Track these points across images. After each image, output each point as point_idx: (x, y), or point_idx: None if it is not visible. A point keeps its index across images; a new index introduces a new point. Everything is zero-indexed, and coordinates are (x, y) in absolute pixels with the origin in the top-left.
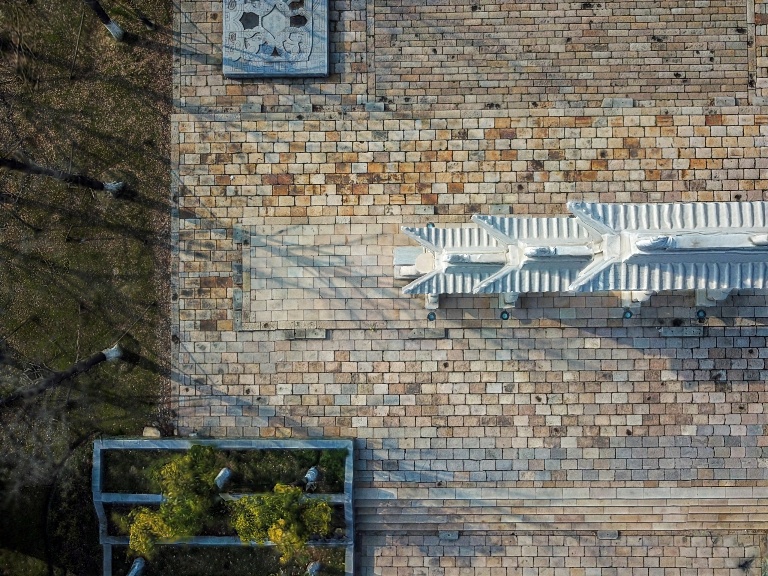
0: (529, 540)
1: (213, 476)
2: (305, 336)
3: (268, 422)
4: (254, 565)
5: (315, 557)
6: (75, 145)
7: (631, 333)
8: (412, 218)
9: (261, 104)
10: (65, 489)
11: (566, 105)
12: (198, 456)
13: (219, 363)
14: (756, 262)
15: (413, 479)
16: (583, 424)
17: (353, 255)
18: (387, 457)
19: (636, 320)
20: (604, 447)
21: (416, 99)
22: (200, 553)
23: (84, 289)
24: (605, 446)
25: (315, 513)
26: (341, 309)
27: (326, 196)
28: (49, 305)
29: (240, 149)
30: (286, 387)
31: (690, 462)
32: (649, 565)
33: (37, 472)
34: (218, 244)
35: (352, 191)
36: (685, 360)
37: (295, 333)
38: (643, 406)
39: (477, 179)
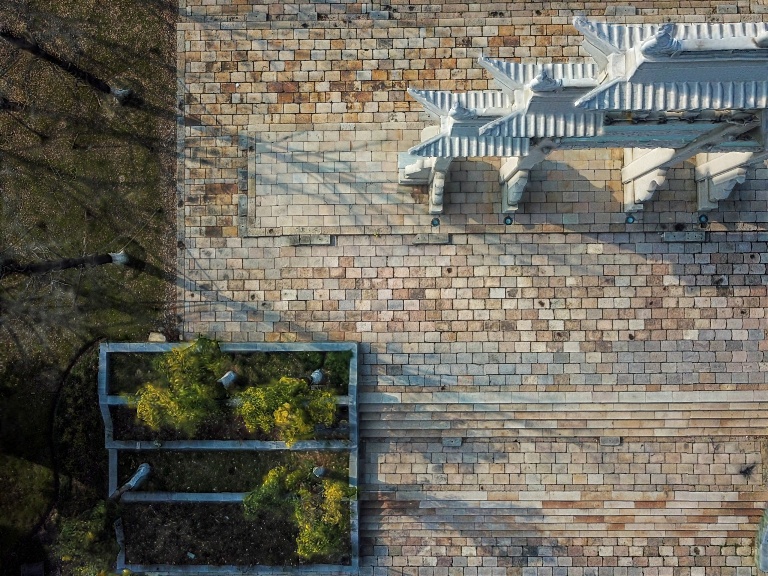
0: (532, 447)
1: (219, 367)
2: (310, 242)
3: (273, 327)
4: (259, 470)
5: (319, 462)
6: (82, 53)
7: (633, 238)
8: (416, 124)
9: (266, 13)
10: (71, 395)
11: (569, 13)
12: (204, 348)
13: (224, 269)
14: (759, 81)
15: (417, 383)
16: (586, 329)
17: (358, 161)
18: (391, 362)
19: (638, 225)
20: (606, 351)
21: (420, 8)
22: (205, 459)
23: (90, 196)
24: (607, 350)
25: (320, 402)
26: (346, 215)
27: (331, 103)
28: (55, 212)
29: (245, 57)
30: (291, 293)
31: (692, 366)
32: (651, 471)
33: (43, 379)
34: (223, 151)
35: (357, 98)
36: (687, 265)
37: (300, 239)
38: (645, 311)
39: (481, 86)
